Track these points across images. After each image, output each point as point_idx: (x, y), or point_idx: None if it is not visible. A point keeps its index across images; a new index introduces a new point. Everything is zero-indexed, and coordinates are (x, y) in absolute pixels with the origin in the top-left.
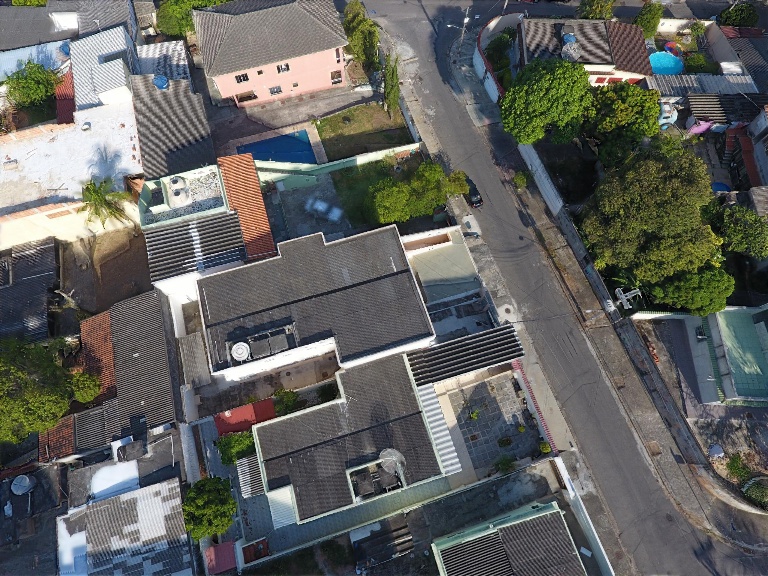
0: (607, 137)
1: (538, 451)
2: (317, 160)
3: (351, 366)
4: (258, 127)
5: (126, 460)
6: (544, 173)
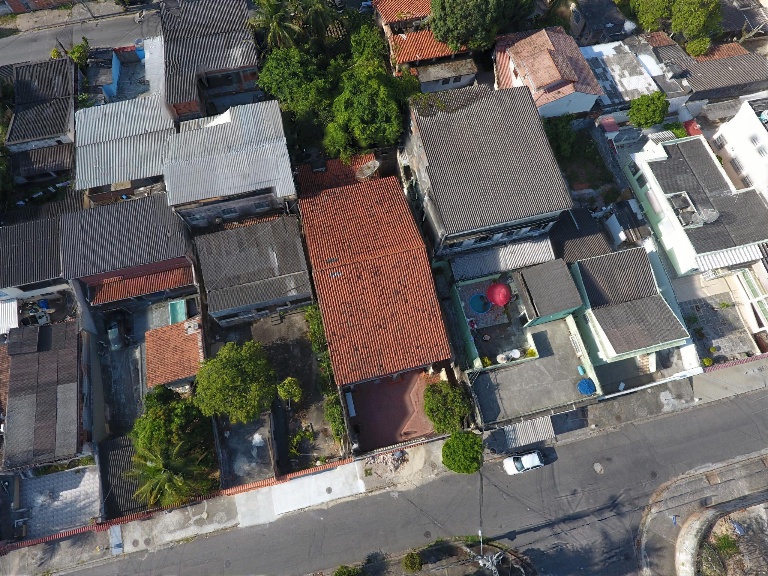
0: None
1: None
2: None
3: (765, 196)
4: None
5: (666, 67)
6: None
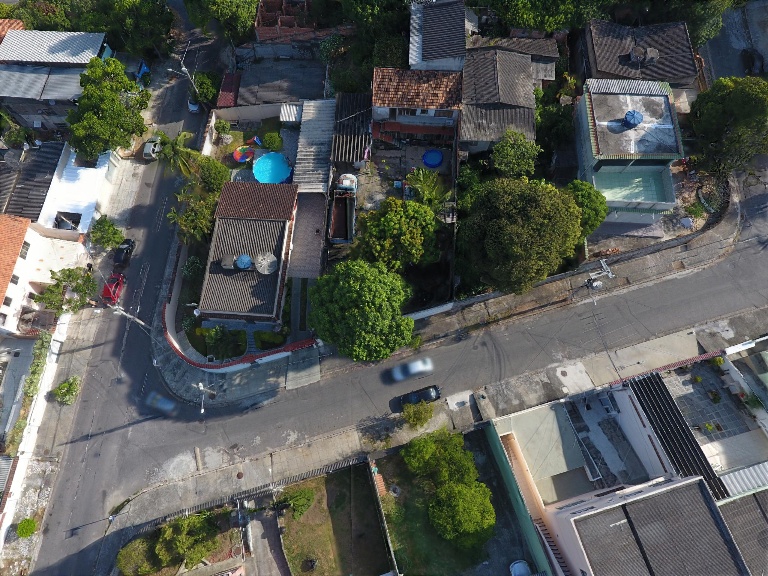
0: None
1: (712, 366)
2: None
3: None
4: None
5: None
6: (411, 315)
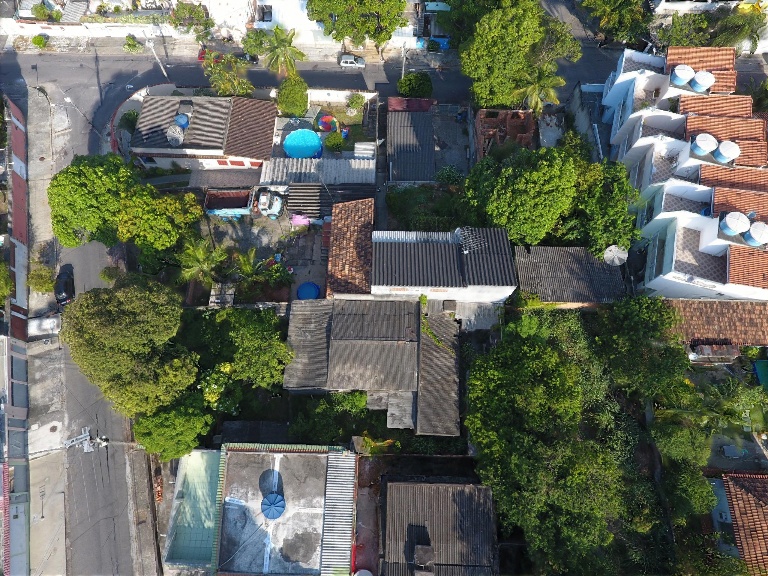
0: None
1: None
2: None
3: None
4: None
5: None
6: None
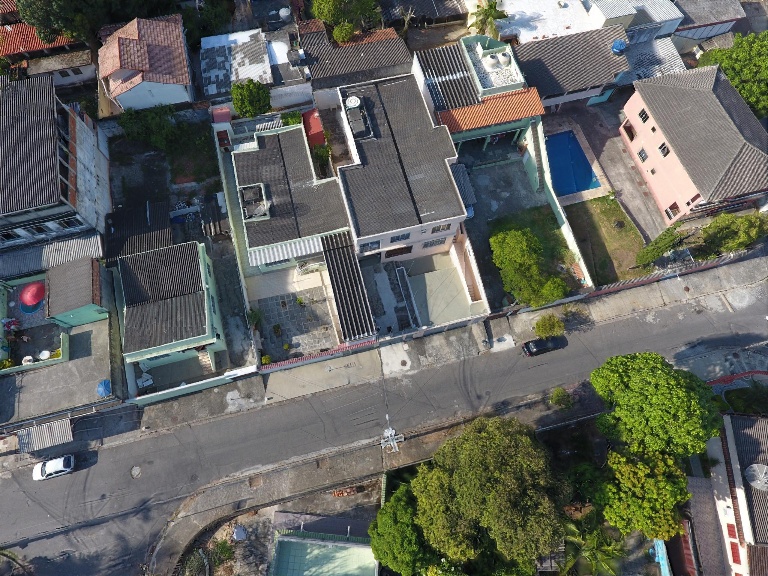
0: (606, 471)
1: None
2: (565, 196)
3: None
4: (599, 147)
5: None
6: None
